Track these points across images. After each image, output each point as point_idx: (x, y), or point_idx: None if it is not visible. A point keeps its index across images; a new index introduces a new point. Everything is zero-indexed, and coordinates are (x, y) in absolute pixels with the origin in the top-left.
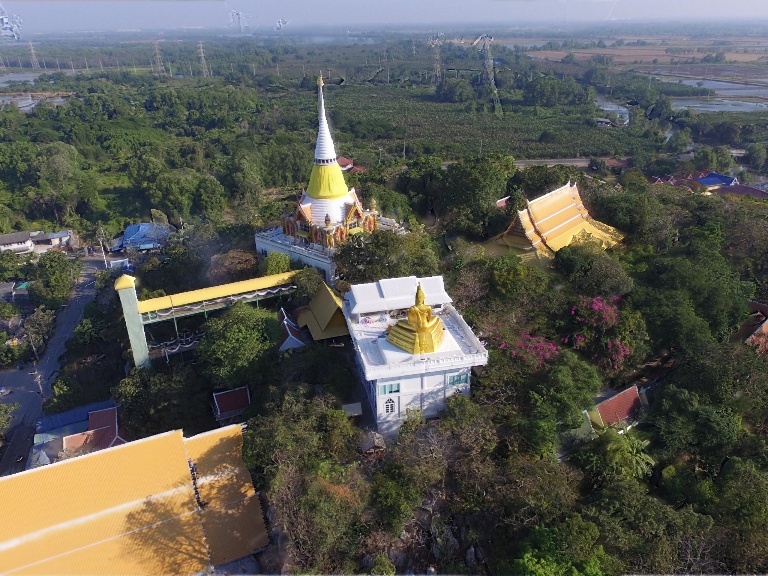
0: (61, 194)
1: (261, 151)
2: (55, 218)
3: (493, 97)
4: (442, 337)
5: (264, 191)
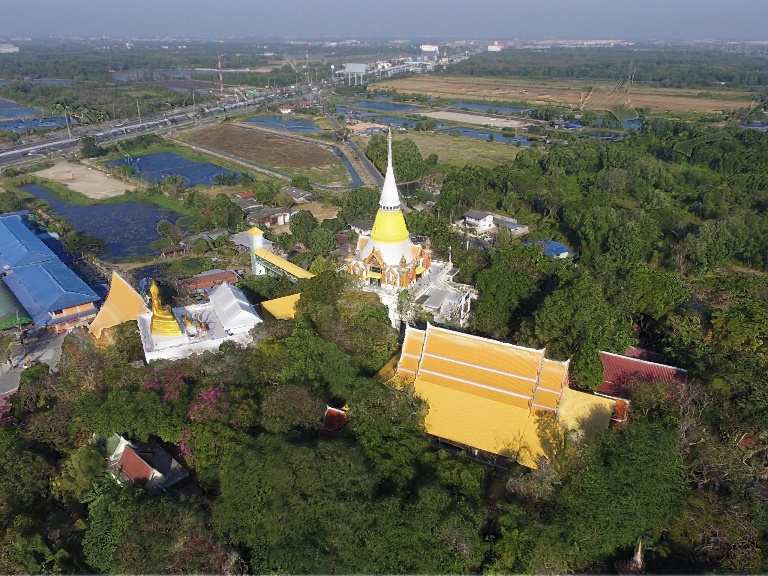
0: (549, 198)
1: (763, 223)
2: (543, 215)
3: (125, 159)
4: (172, 333)
5: (742, 269)
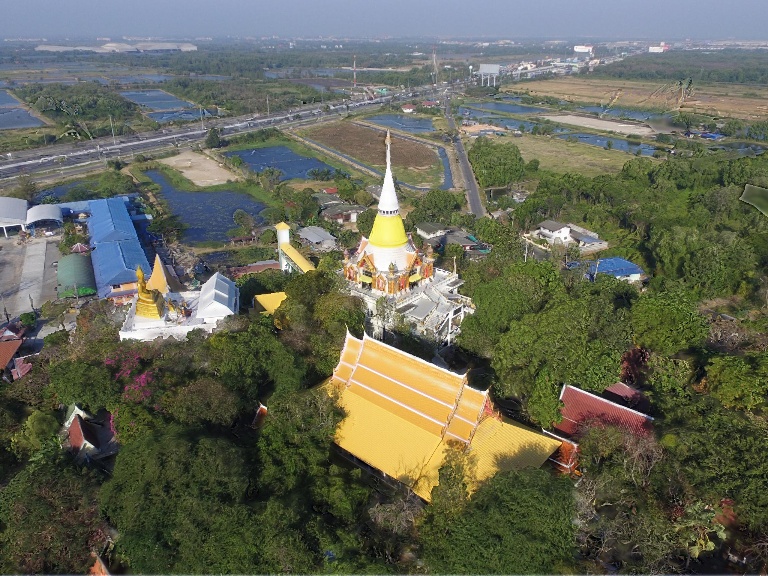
0: (637, 213)
1: None
2: (630, 232)
3: None
4: (151, 316)
5: None
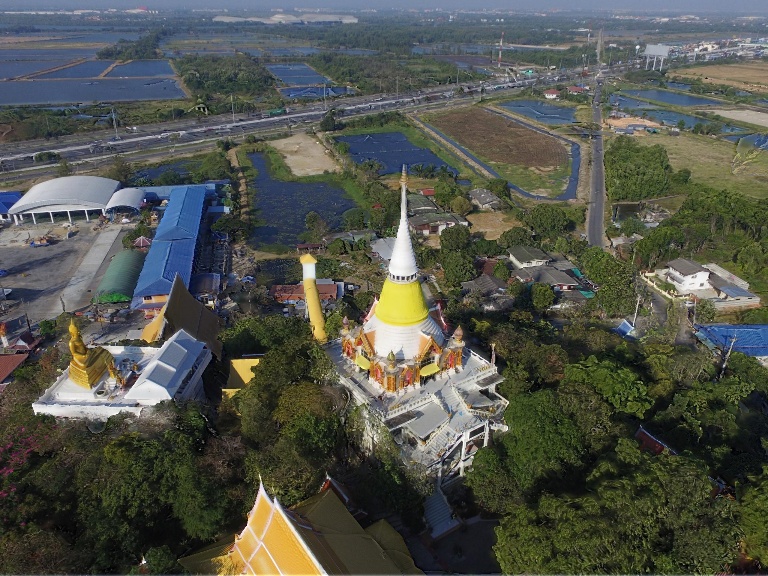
0: None
1: None
2: None
3: None
4: (82, 384)
5: None
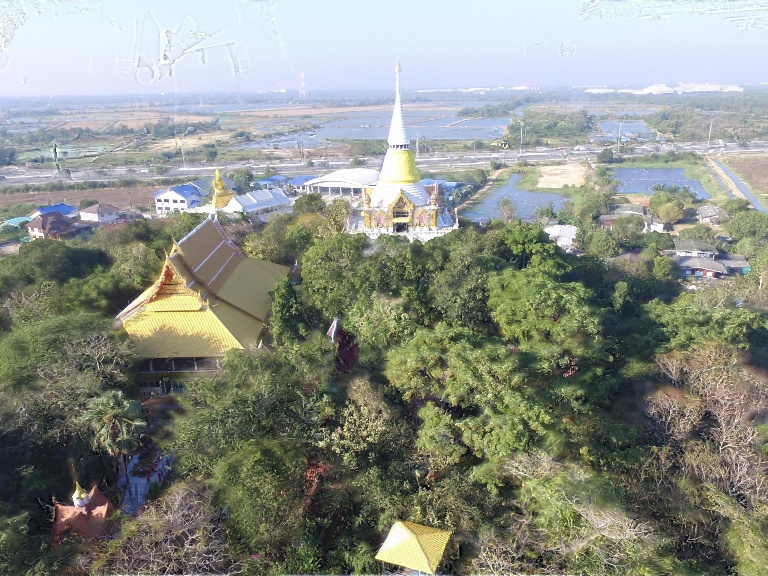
0: None
1: None
2: None
3: None
4: None
5: None
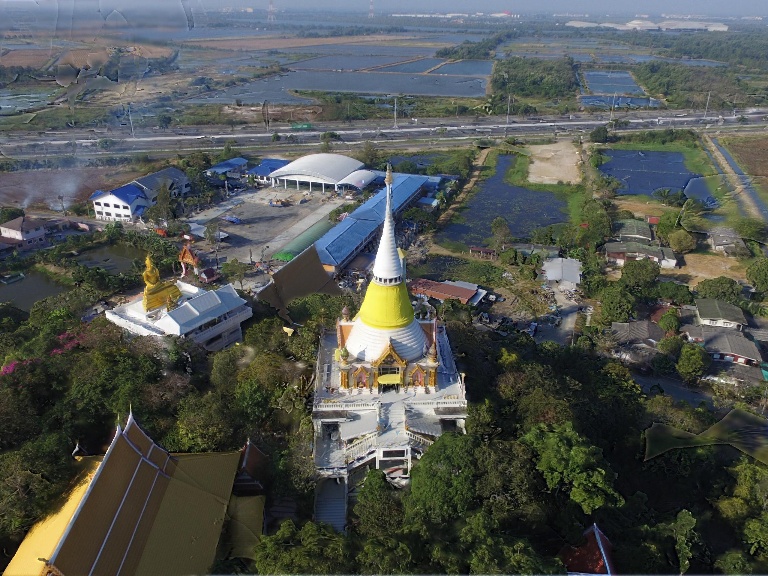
0: None
1: None
2: None
3: None
4: None
5: None
